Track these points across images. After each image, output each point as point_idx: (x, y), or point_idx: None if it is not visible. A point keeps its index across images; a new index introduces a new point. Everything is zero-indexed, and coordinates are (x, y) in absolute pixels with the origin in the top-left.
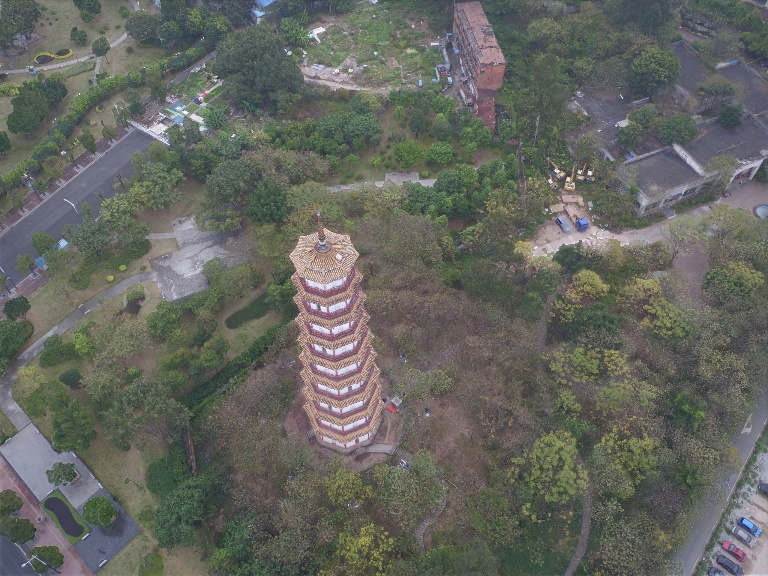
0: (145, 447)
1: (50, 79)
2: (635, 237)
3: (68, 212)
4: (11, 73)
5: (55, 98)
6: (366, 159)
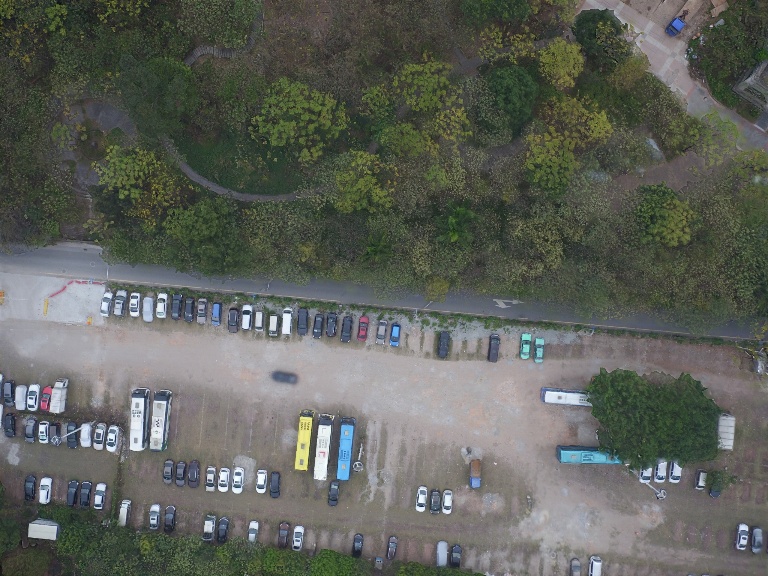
0: None
1: None
2: (698, 98)
3: None
4: None
5: None
6: None
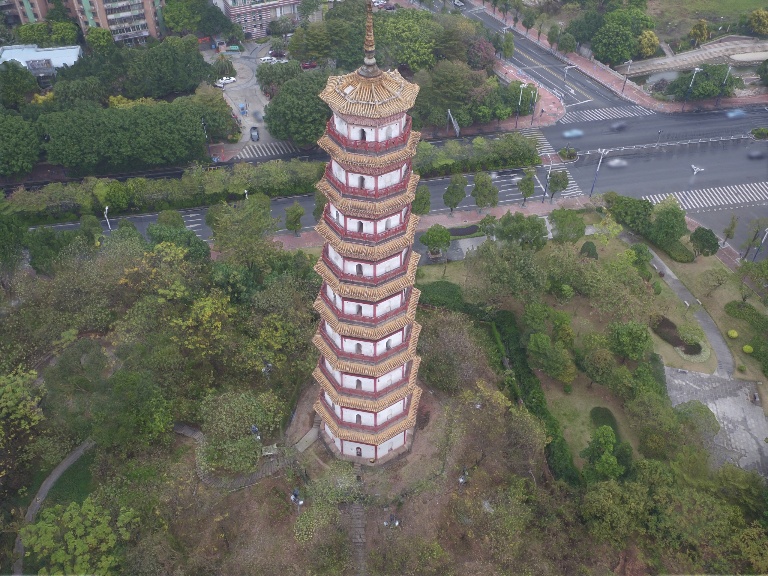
0: (467, 266)
1: None
2: None
3: None
4: None
5: None
6: None
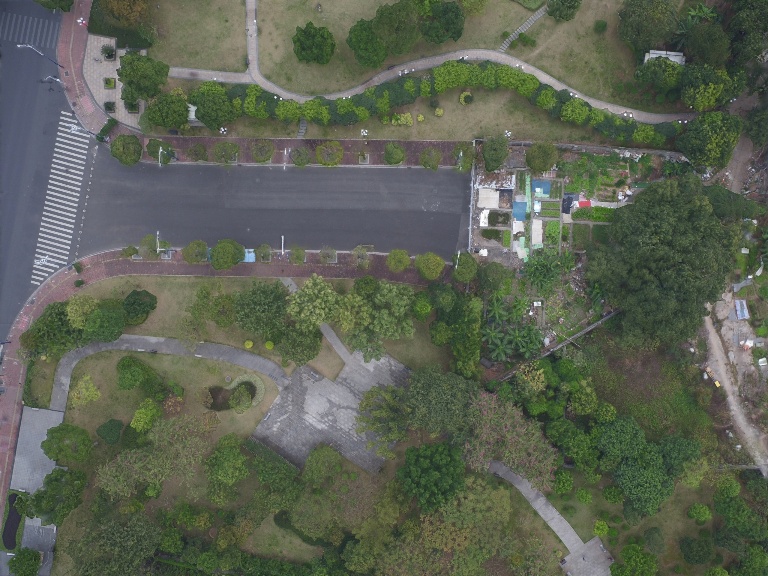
0: None
1: None
2: None
3: (299, 209)
4: None
5: (435, 39)
6: None
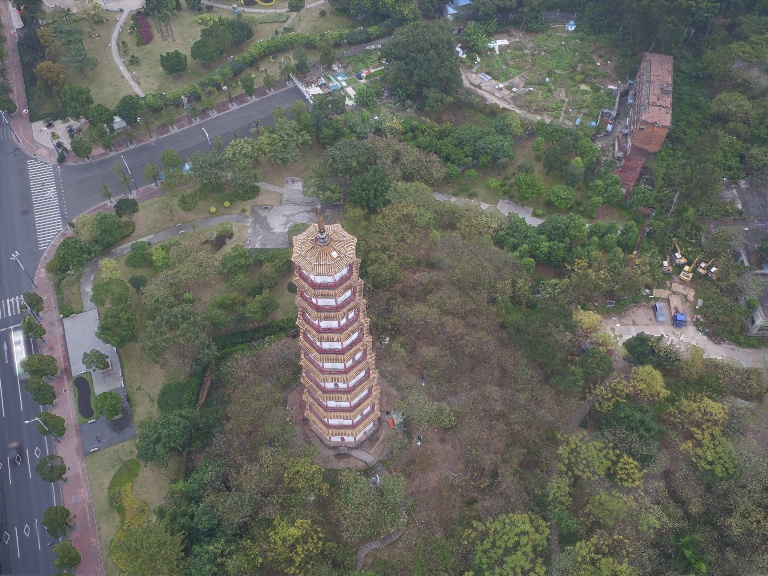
0: (166, 366)
1: (243, 20)
2: (734, 354)
3: (207, 140)
4: (218, 6)
5: (239, 38)
6: (488, 179)
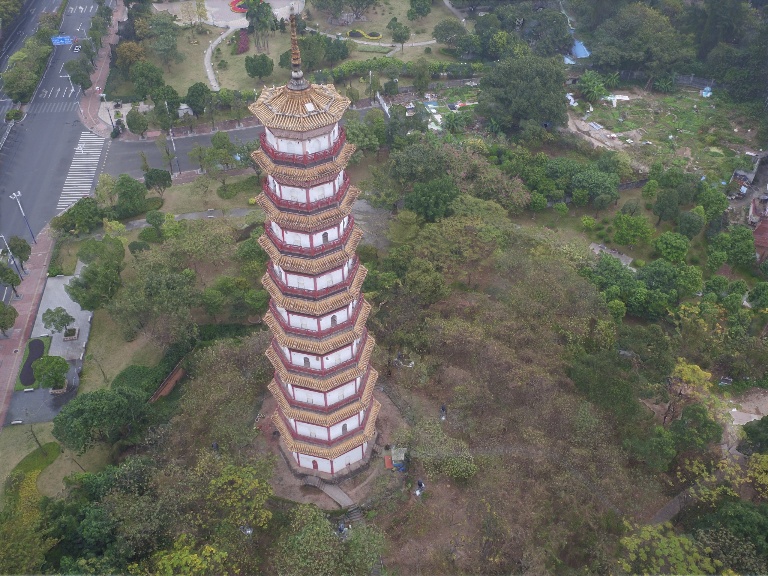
0: (130, 337)
1: (342, 42)
2: None
3: None
4: None
5: (333, 55)
6: None
